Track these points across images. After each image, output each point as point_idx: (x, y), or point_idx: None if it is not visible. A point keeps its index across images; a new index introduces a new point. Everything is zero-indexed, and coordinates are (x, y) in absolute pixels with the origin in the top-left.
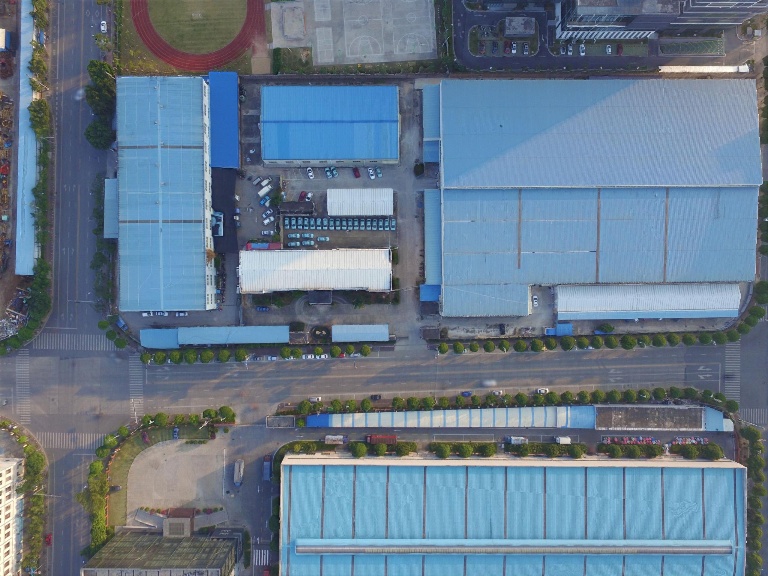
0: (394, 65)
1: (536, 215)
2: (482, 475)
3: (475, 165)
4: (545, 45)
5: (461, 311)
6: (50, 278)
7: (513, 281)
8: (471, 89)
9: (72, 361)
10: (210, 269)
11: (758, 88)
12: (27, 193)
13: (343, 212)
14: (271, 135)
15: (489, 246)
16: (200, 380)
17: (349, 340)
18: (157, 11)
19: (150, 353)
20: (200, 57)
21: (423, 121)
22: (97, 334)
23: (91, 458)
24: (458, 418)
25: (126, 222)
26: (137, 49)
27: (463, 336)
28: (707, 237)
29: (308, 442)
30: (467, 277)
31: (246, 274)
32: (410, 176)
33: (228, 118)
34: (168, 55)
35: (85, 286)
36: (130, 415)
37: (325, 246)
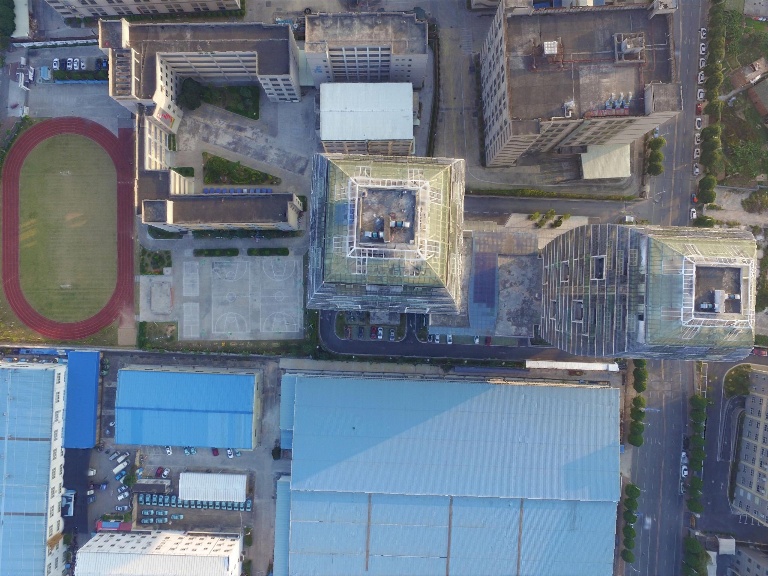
0: (259, 344)
1: (386, 519)
2: None
3: (324, 468)
4: (413, 331)
5: None
6: None
7: None
8: (326, 387)
9: None
10: (55, 553)
11: (630, 383)
12: None
13: (195, 498)
14: (125, 421)
15: (337, 547)
16: None
17: None
18: (28, 278)
19: None
20: (67, 326)
21: None
22: None
23: None
24: None
25: None
26: (5, 316)
27: None
28: (562, 548)
29: None
30: None
31: (82, 575)
32: (269, 456)
33: (85, 398)
34: (36, 322)
35: None
36: None
37: (179, 523)
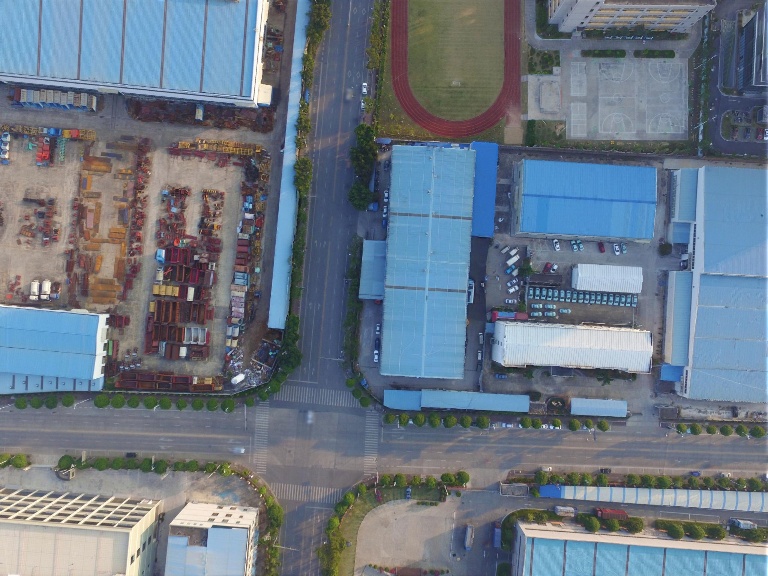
0: (645, 144)
1: None
2: (721, 560)
3: (735, 253)
4: None
5: (706, 394)
6: (296, 332)
7: (760, 368)
8: (733, 177)
9: (311, 415)
10: None
11: None
12: (284, 248)
13: (592, 287)
14: (531, 208)
15: (740, 332)
16: (434, 442)
17: (587, 414)
18: (416, 76)
19: (388, 412)
20: (455, 124)
21: (677, 203)
22: (337, 390)
23: (323, 512)
24: (689, 498)
25: (392, 287)
26: (395, 112)
27: (695, 416)
28: None
29: (539, 512)
30: (715, 361)
31: (510, 348)
32: (653, 254)
33: (487, 188)
34: (424, 120)
35: (328, 341)
36: (363, 472)
37: (566, 318)
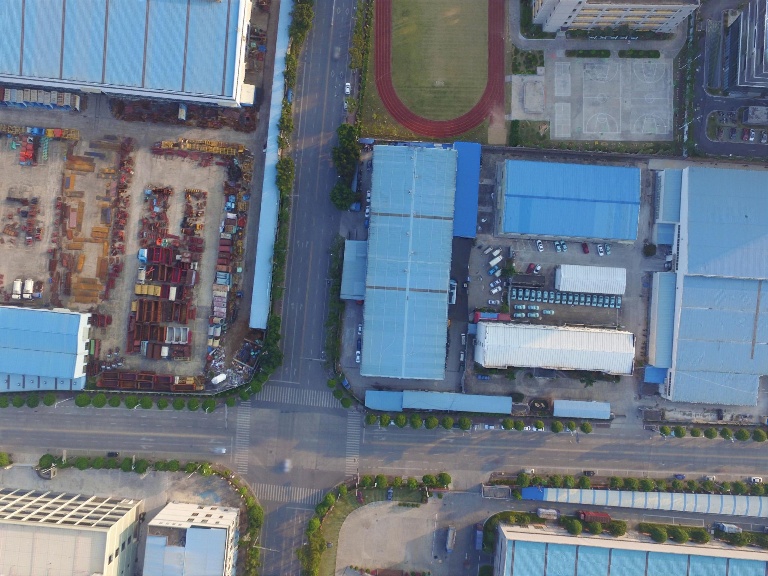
0: (630, 144)
1: None
2: (704, 564)
3: (719, 254)
4: None
5: (690, 397)
6: (278, 332)
7: (744, 371)
8: (717, 177)
9: (292, 415)
10: None
11: None
12: (266, 248)
13: (575, 289)
14: (513, 209)
15: (724, 334)
16: (416, 443)
17: (570, 416)
18: (400, 76)
19: (369, 413)
20: (438, 124)
21: (661, 204)
22: (319, 390)
23: (304, 513)
24: (673, 502)
25: (373, 288)
26: (378, 112)
27: (680, 418)
28: None
29: (521, 514)
30: (699, 364)
31: (491, 349)
32: (638, 255)
33: (469, 188)
34: (407, 120)
35: (310, 342)
36: (345, 473)
37: (549, 319)
